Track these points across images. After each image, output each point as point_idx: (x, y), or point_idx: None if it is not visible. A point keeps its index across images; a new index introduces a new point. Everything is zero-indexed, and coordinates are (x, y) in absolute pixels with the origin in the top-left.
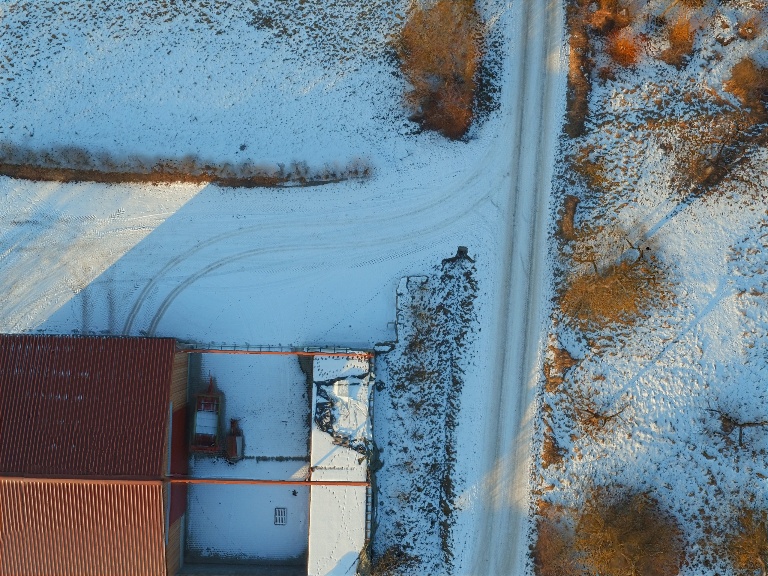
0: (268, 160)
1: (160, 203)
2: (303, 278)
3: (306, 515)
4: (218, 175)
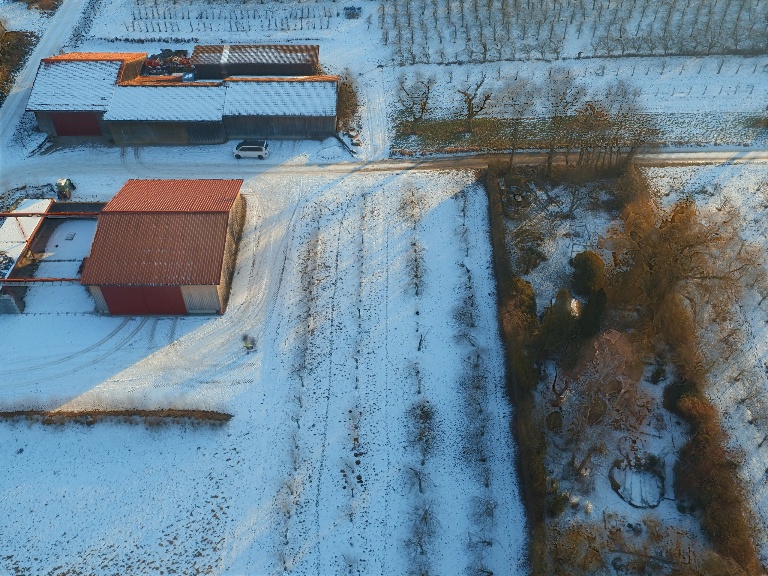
0: (0, 439)
1: (97, 398)
2: (2, 355)
3: (54, 237)
4: (40, 417)
